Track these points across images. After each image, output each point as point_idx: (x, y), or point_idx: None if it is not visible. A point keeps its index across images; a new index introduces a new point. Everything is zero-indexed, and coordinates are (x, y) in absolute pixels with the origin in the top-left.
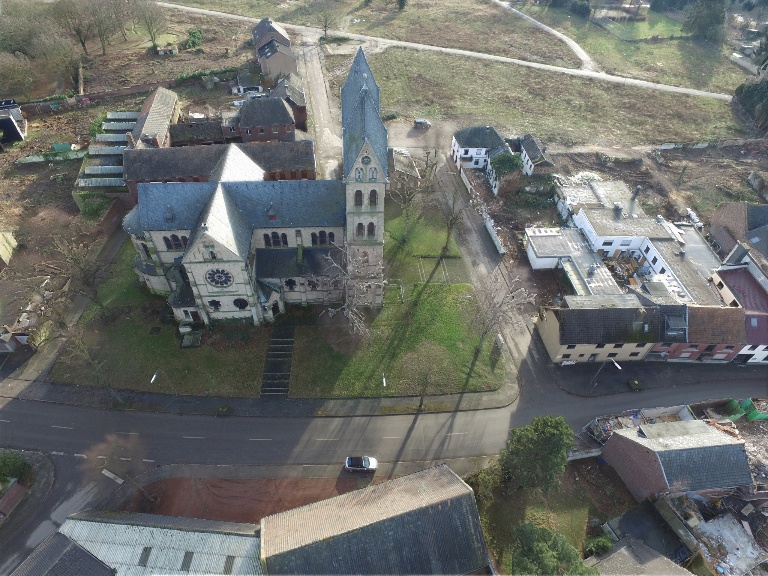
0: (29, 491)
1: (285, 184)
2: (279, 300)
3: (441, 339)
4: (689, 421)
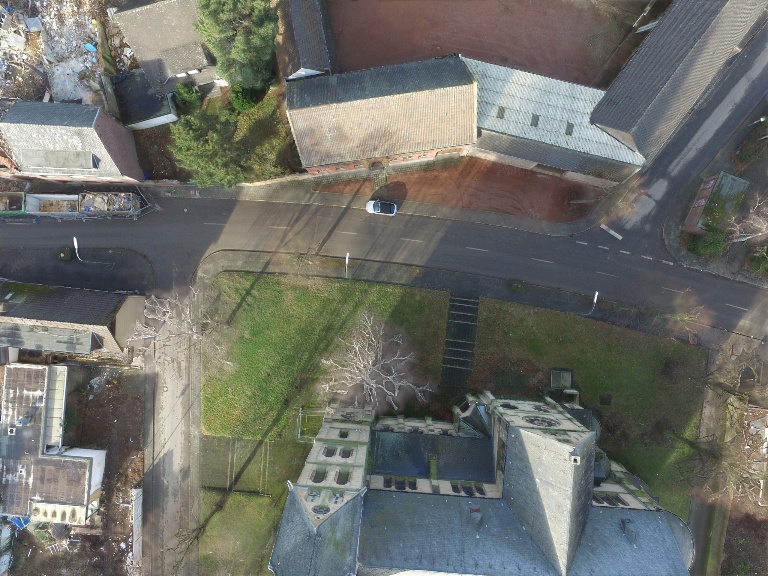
0: (682, 228)
1: (457, 567)
2: (461, 414)
3: (267, 344)
4: (37, 165)
